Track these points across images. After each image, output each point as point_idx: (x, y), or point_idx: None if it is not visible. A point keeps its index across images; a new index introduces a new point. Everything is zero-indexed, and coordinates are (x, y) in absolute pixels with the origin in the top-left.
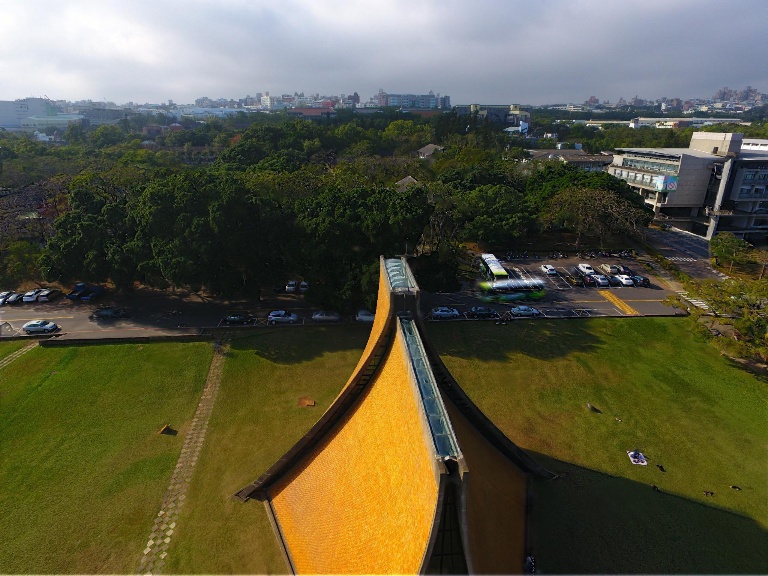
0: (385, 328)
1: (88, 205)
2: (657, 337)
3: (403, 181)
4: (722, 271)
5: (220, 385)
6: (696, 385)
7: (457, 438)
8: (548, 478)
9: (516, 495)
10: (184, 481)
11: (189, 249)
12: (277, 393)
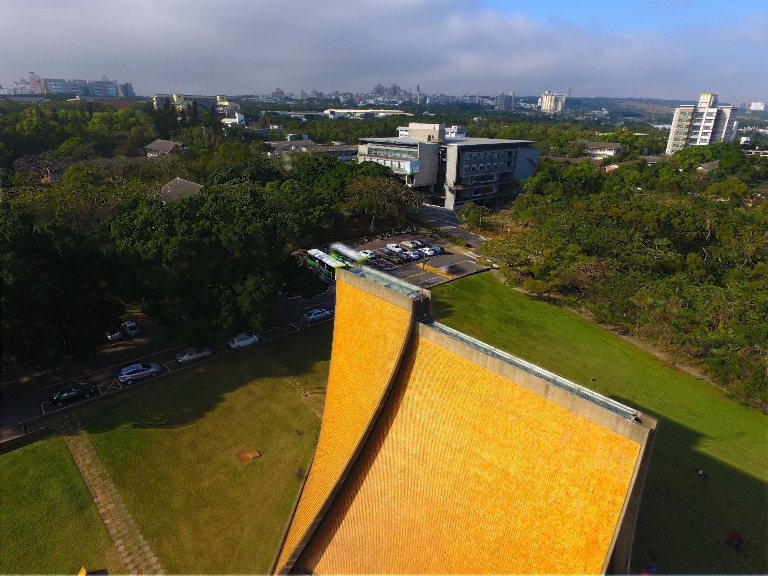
0: (407, 337)
1: None
2: (480, 291)
3: (173, 184)
4: (476, 232)
5: (115, 485)
6: (525, 320)
7: None
8: None
9: None
10: None
11: None
12: (204, 461)
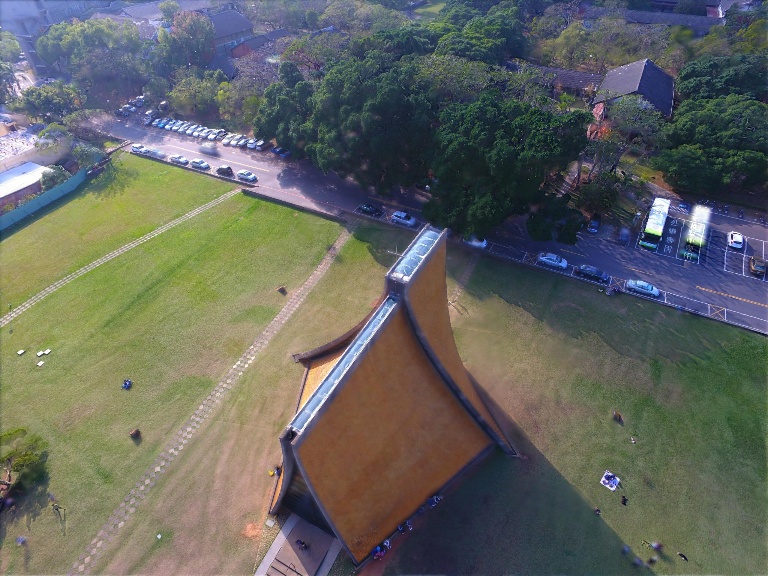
0: (381, 299)
1: (289, 78)
2: None
3: (632, 66)
4: None
5: (330, 266)
6: None
7: (411, 398)
8: (508, 453)
9: (463, 452)
10: (273, 332)
11: (340, 142)
12: (363, 288)
